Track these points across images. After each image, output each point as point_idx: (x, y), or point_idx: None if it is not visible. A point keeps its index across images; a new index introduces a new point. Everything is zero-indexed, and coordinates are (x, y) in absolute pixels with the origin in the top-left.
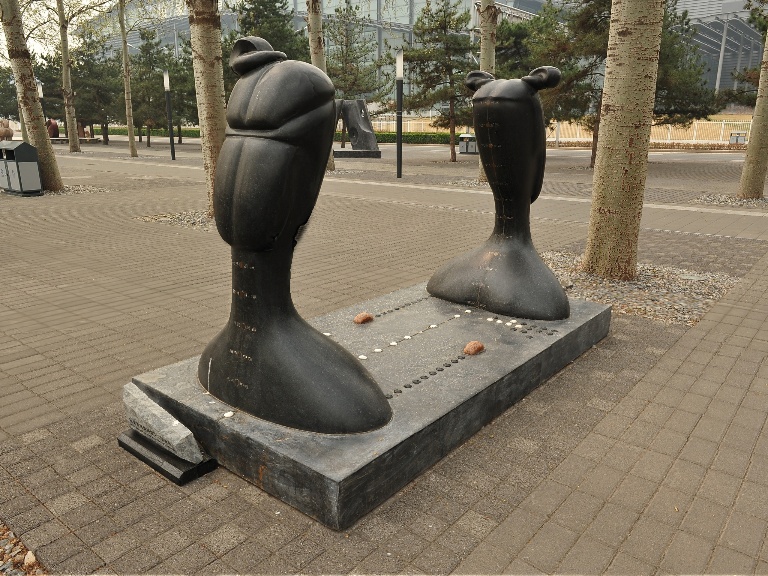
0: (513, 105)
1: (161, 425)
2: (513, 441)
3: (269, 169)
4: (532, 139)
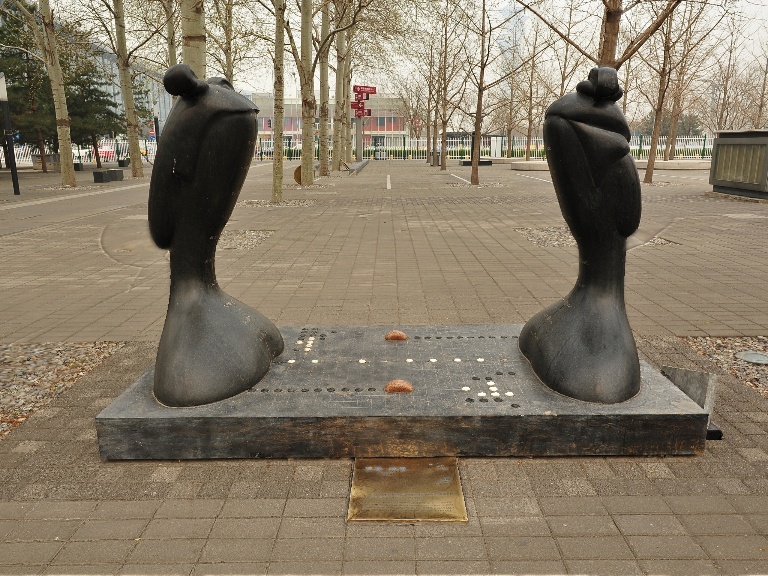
0: None
1: None
2: None
3: None
4: None
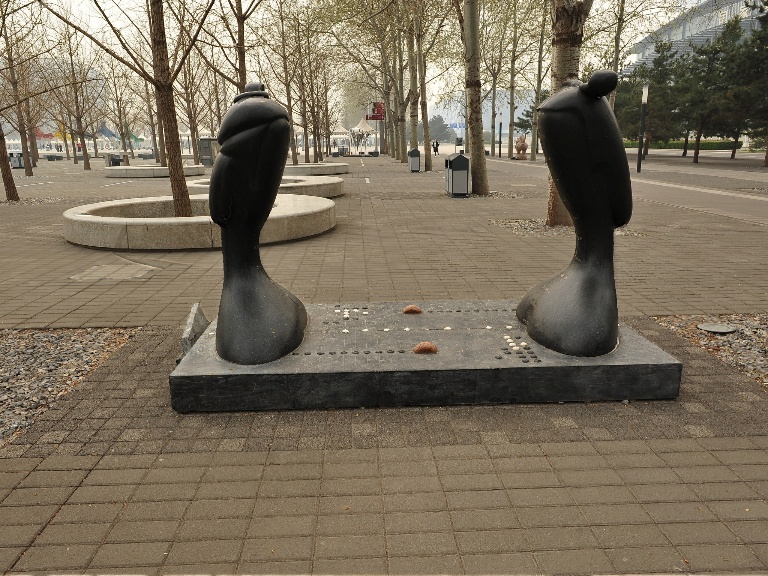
0: (556, 115)
1: None
2: (361, 424)
3: (215, 172)
4: (586, 152)
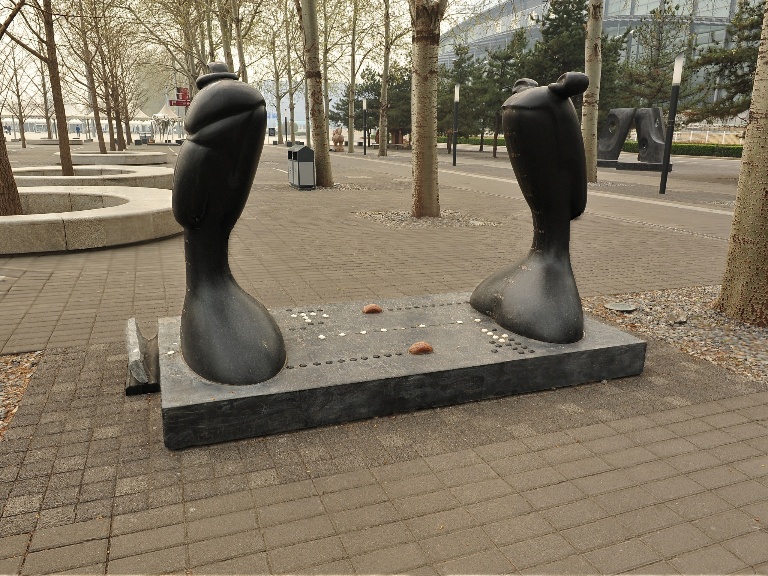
0: (529, 113)
1: (129, 350)
2: (386, 435)
3: (186, 165)
4: (555, 149)
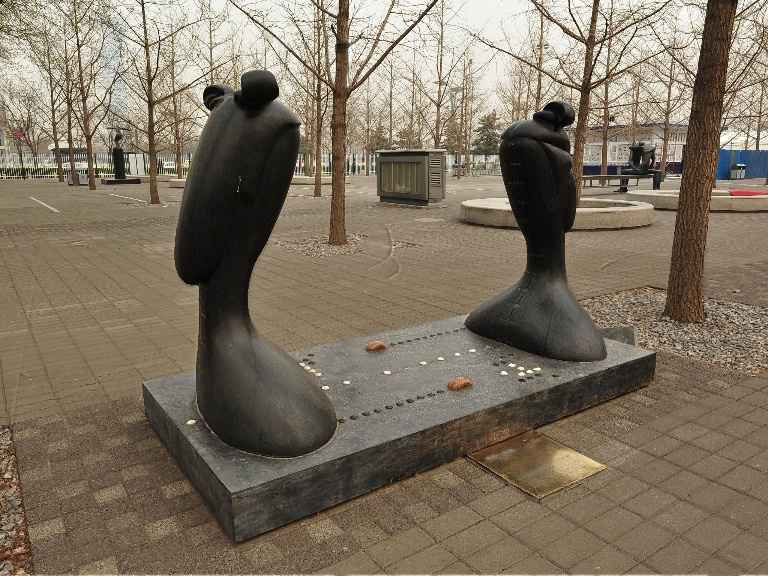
0: None
1: None
2: None
3: None
4: None
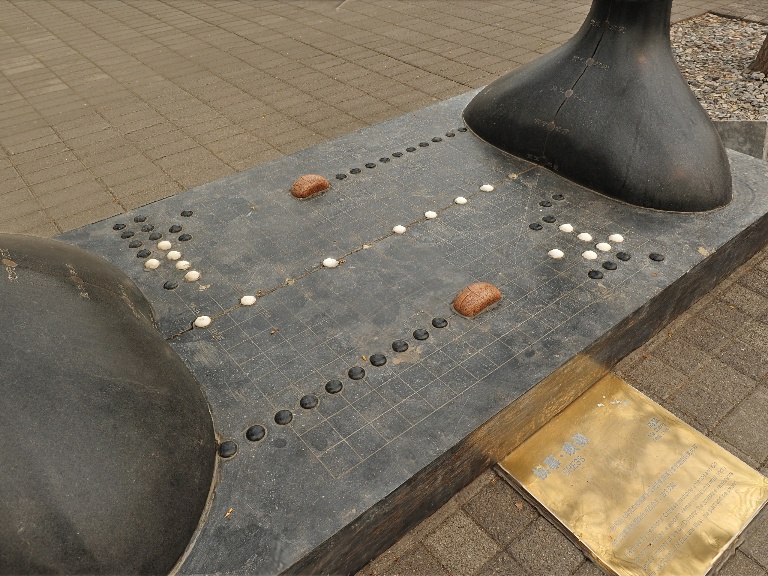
0: None
1: None
2: None
3: None
4: None
